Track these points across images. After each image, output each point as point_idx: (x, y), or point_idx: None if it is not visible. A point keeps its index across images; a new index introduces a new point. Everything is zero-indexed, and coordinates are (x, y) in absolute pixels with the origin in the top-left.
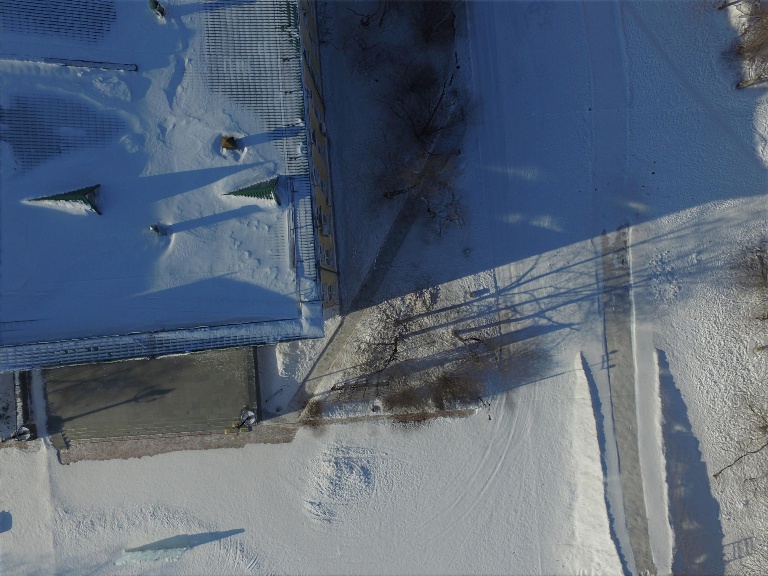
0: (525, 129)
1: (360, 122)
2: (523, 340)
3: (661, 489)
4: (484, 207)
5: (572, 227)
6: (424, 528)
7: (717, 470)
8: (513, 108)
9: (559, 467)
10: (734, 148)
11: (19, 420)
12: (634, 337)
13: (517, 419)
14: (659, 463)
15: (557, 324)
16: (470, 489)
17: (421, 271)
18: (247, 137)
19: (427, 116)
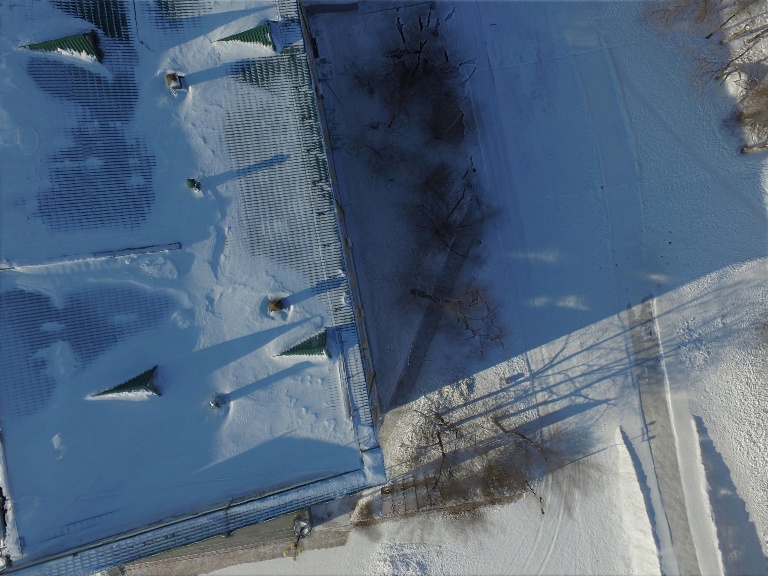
0: (541, 212)
1: (380, 223)
2: (562, 420)
3: (715, 556)
4: (510, 293)
5: (598, 304)
6: None
7: (766, 529)
8: (527, 193)
9: (611, 542)
10: (746, 210)
11: None
12: (670, 406)
13: (565, 499)
14: (710, 530)
15: (594, 401)
16: (526, 573)
17: (455, 362)
18: (292, 295)
19: (445, 211)
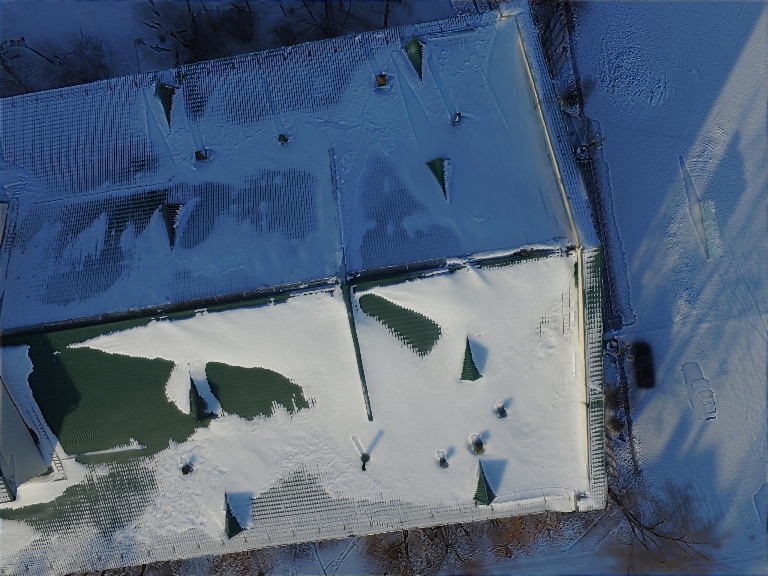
0: None
1: None
2: None
3: None
4: None
5: None
6: (665, 1)
7: None
8: None
9: None
10: None
11: None
12: None
13: None
14: None
15: None
16: None
17: None
18: (374, 73)
19: None
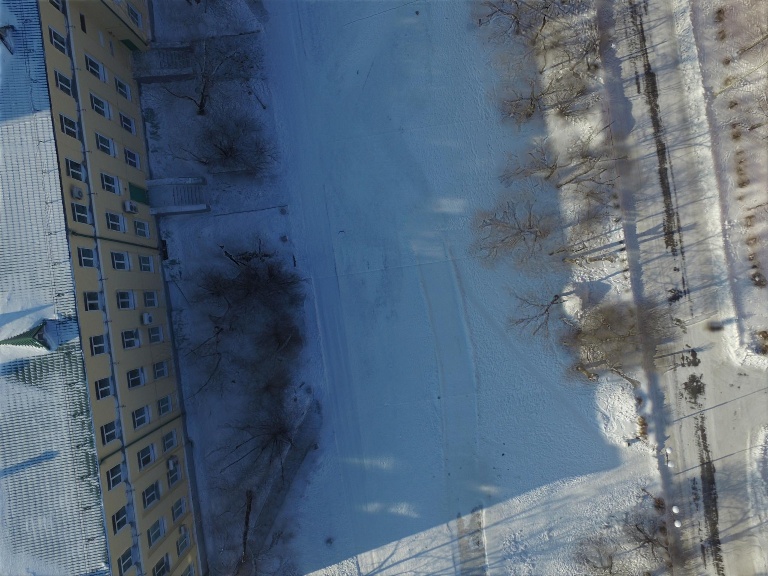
0: (379, 419)
1: (220, 424)
2: None
3: None
4: (344, 497)
5: (428, 512)
6: None
7: None
8: (366, 399)
9: None
10: (579, 426)
11: None
12: None
13: None
14: None
15: None
16: None
17: None
18: None
19: (282, 417)
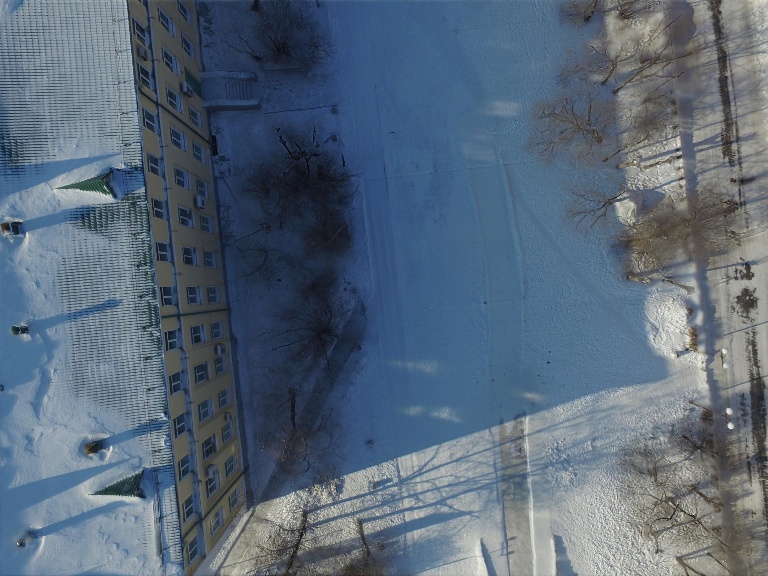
0: (424, 322)
1: (265, 321)
2: (426, 527)
3: None
4: (386, 399)
5: (471, 417)
6: None
7: None
8: (411, 303)
9: None
10: (627, 336)
11: None
12: (532, 524)
13: None
14: None
15: (458, 511)
16: None
17: (327, 462)
18: (112, 436)
19: (327, 315)
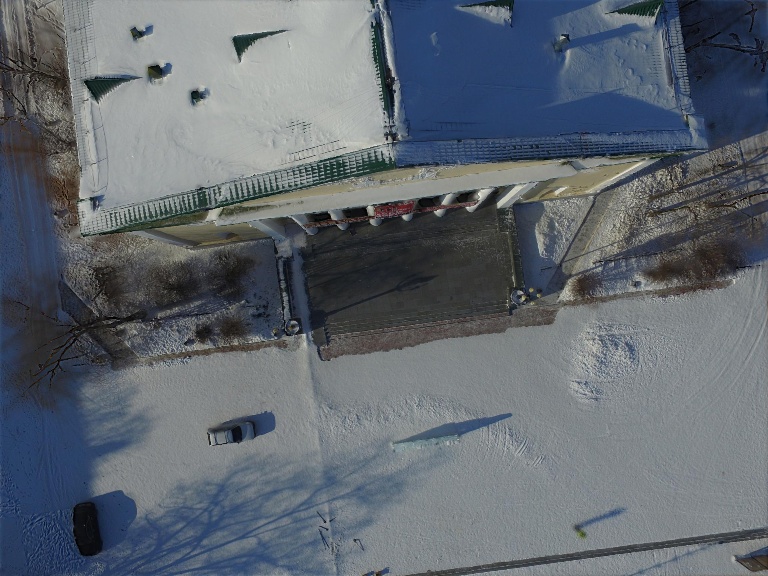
0: (757, 6)
1: None
2: None
3: None
4: (724, 83)
5: None
6: (691, 401)
7: None
8: None
9: None
10: None
11: (286, 314)
12: None
13: None
14: None
15: None
16: (734, 359)
17: None
18: None
19: None
